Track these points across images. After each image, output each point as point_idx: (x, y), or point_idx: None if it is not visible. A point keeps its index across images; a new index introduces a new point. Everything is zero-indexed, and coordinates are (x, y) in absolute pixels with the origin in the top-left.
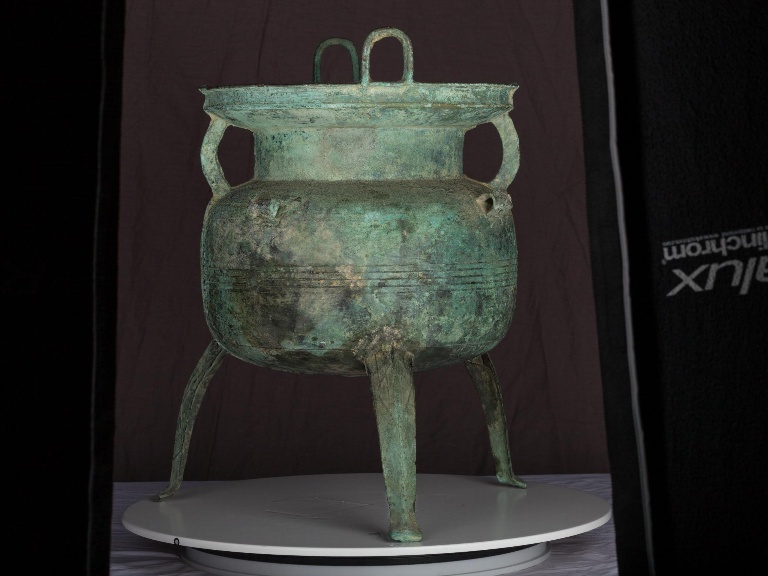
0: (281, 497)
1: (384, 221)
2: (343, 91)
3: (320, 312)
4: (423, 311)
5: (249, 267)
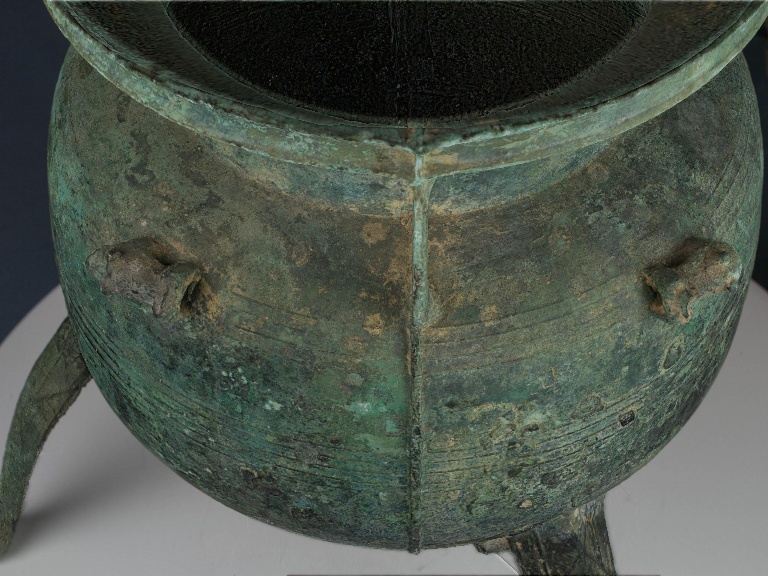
0: None
1: None
2: None
3: None
4: None
5: None
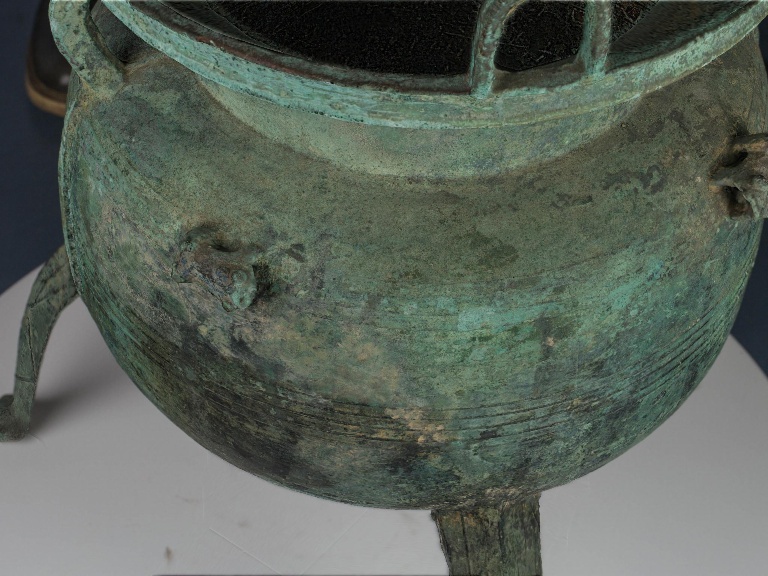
0: None
1: (504, 326)
2: (422, 95)
3: (346, 469)
4: (575, 451)
5: (180, 345)
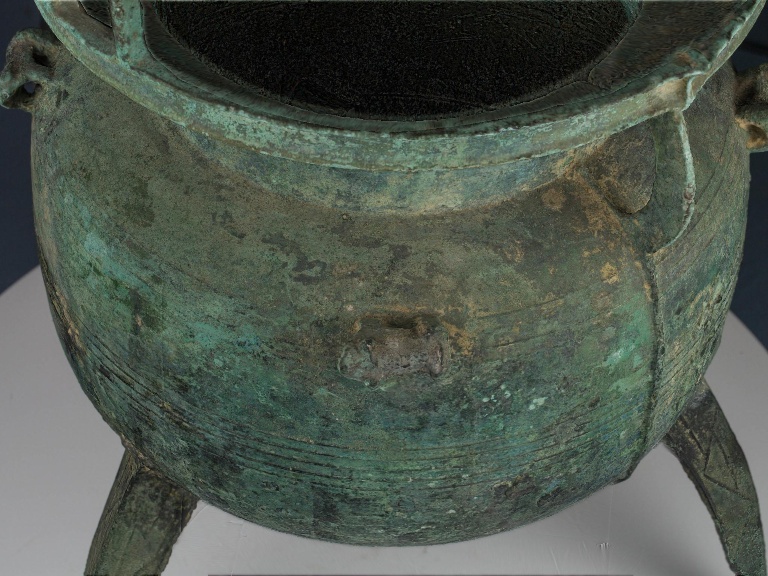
0: None
1: (109, 272)
2: None
3: None
4: (180, 461)
5: None
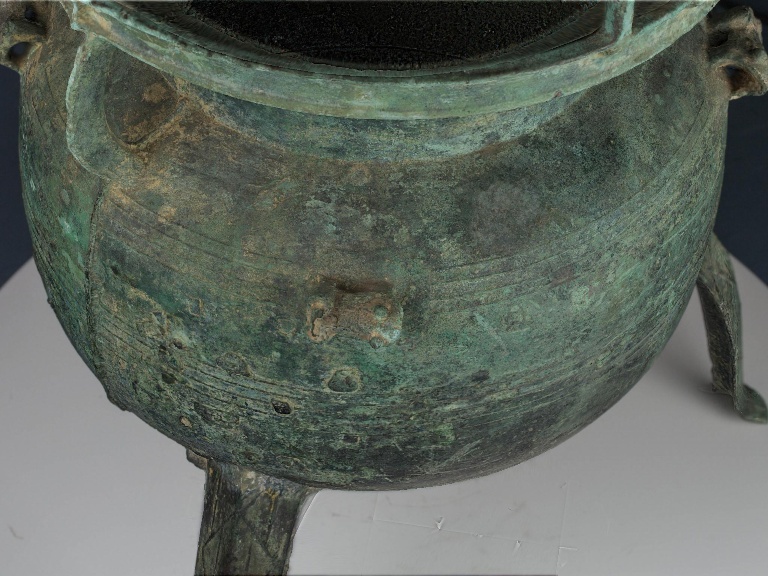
0: (582, 522)
1: None
2: None
3: None
4: None
5: None
